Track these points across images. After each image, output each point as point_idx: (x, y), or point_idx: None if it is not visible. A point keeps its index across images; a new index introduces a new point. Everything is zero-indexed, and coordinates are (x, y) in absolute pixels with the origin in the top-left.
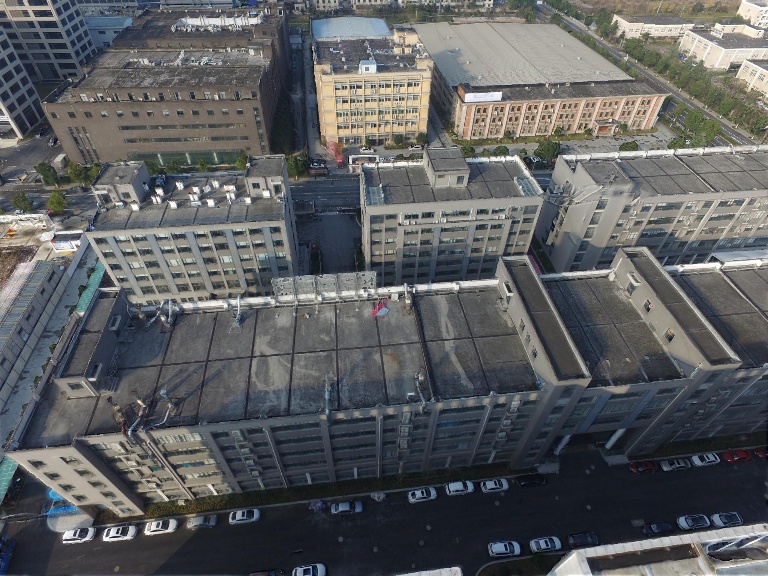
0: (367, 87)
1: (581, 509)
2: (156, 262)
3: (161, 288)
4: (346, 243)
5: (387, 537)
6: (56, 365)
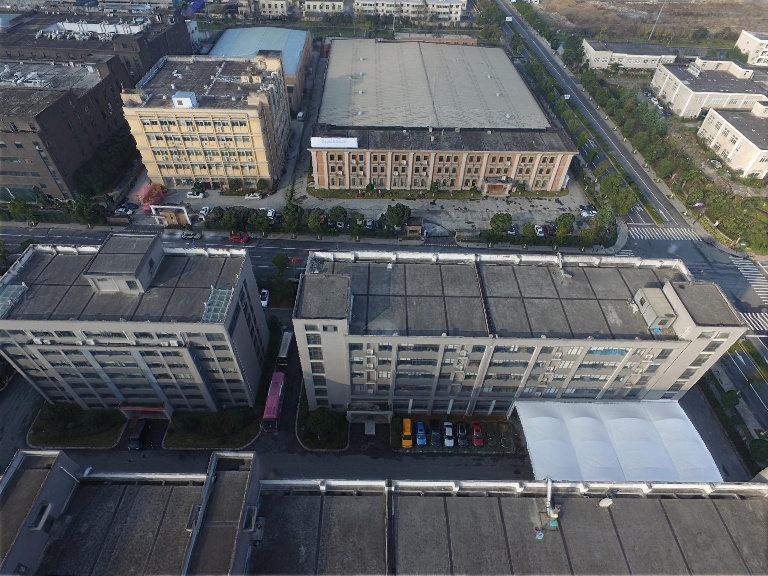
0: (182, 124)
1: None
2: None
3: None
4: None
5: None
6: None
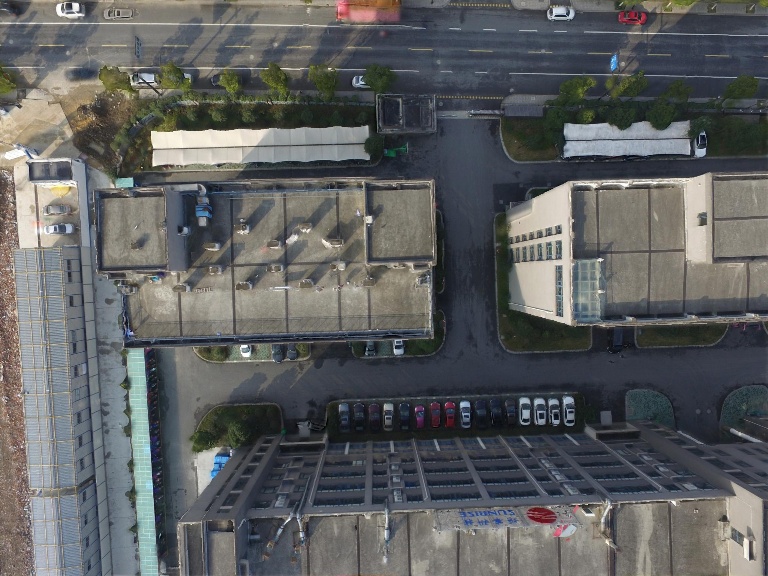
0: None
1: None
2: None
3: None
4: (482, 196)
5: None
6: None
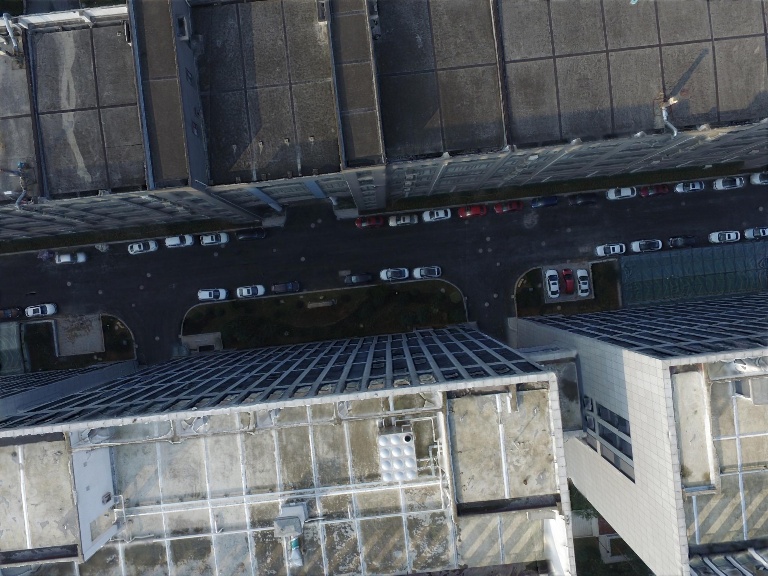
0: None
1: (294, 260)
2: None
3: None
4: None
5: (110, 282)
6: None
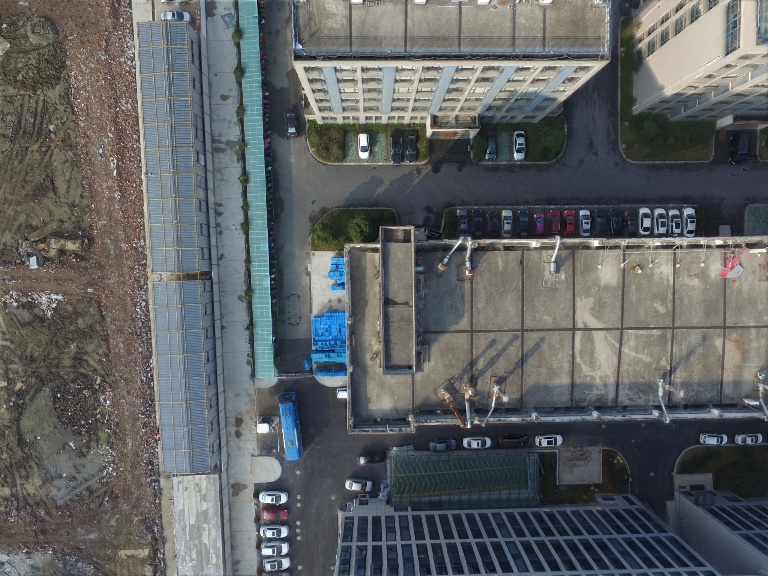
0: None
1: None
2: (379, 88)
3: (369, 107)
4: None
5: None
6: (351, 322)
